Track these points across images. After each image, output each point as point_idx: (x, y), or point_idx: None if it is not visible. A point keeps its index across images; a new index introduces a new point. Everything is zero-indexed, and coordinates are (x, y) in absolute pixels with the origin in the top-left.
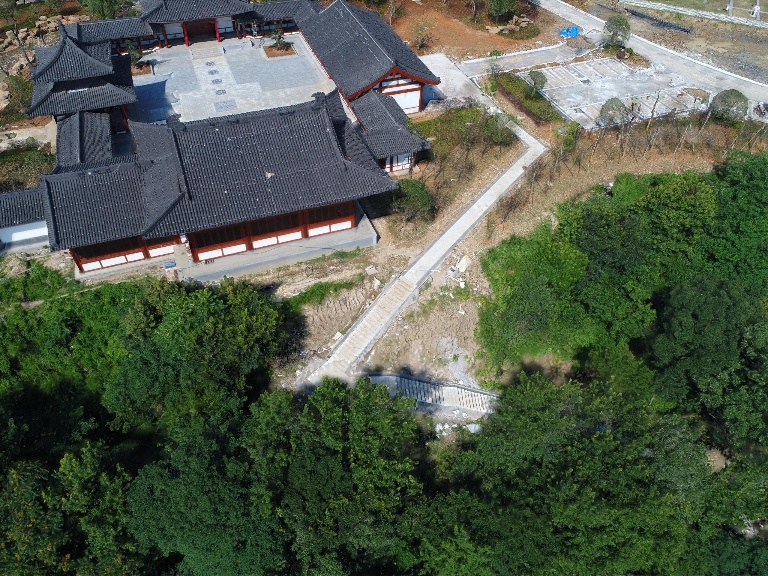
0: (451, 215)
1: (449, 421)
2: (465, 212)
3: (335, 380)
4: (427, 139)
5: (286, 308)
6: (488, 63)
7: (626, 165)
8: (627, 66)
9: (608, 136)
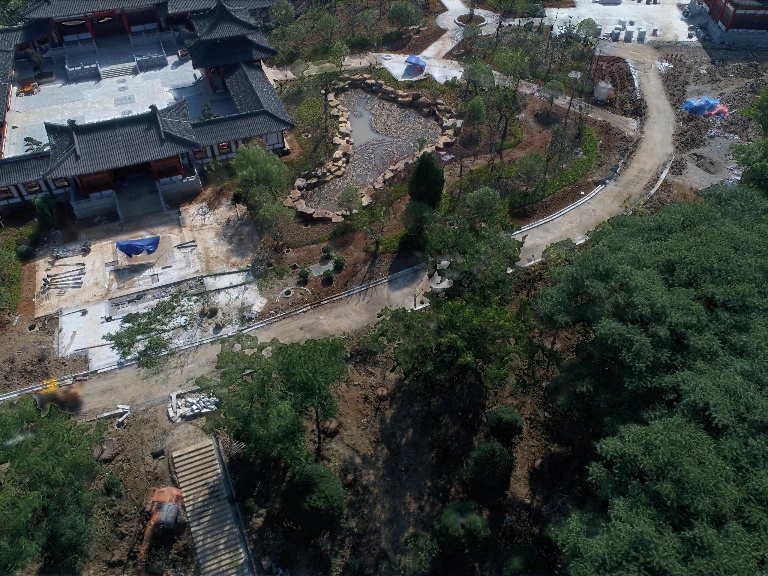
0: None
1: None
2: None
3: None
4: None
5: None
6: None
7: None
8: None
9: None
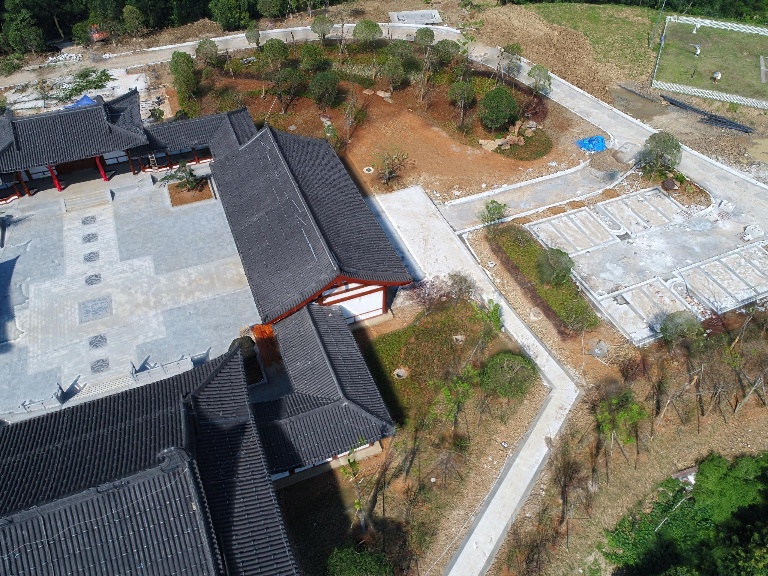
0: (432, 571)
1: None
2: (455, 560)
3: None
4: (394, 373)
5: None
6: (483, 203)
7: (710, 434)
8: (679, 204)
9: (673, 364)
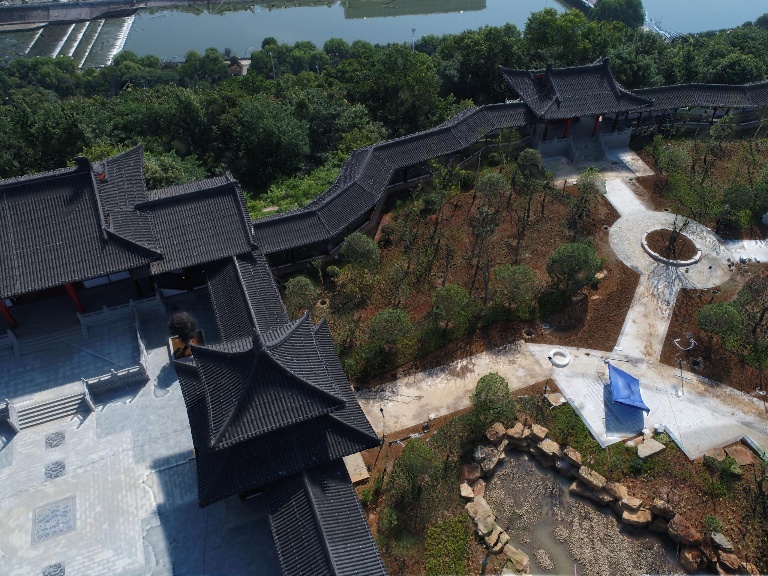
0: None
1: None
2: None
3: (41, 112)
4: None
5: None
6: None
7: None
8: None
9: None
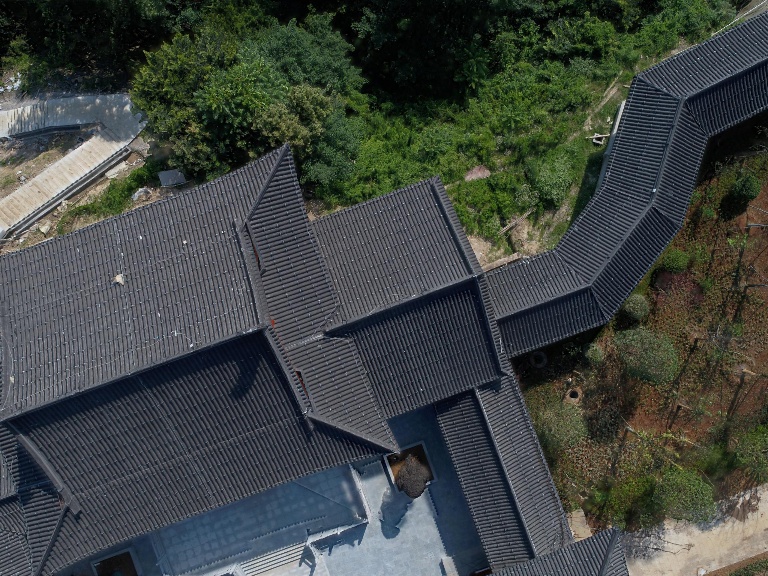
0: None
1: (7, 96)
2: None
3: None
4: None
5: (151, 163)
6: None
7: None
8: None
9: None
